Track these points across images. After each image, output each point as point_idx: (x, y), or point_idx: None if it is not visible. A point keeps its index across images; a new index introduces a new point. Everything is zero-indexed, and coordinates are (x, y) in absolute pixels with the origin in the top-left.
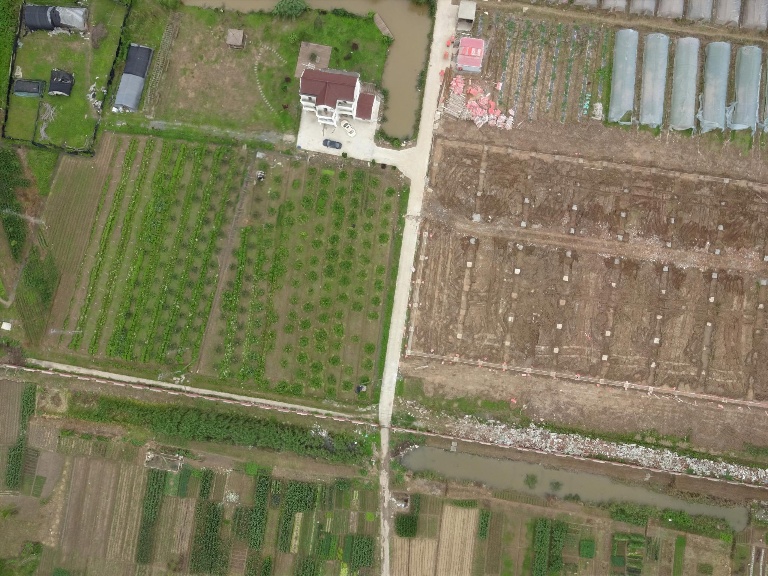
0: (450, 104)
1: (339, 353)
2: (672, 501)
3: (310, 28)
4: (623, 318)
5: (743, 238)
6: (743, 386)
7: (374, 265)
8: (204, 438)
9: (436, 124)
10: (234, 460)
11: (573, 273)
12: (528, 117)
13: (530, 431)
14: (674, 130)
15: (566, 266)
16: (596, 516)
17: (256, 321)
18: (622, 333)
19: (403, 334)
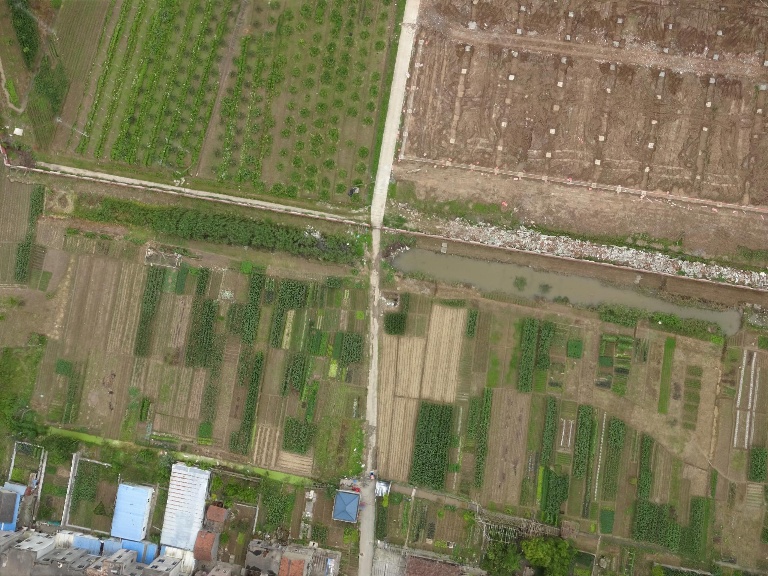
0: None
1: (334, 157)
2: (663, 305)
3: None
4: (617, 122)
5: (743, 43)
6: (739, 190)
7: (370, 72)
8: (201, 236)
9: None
10: (230, 259)
11: (568, 79)
12: None
13: (520, 232)
14: None
15: (561, 72)
16: (585, 317)
17: (254, 126)
18: (616, 137)
19: (397, 138)
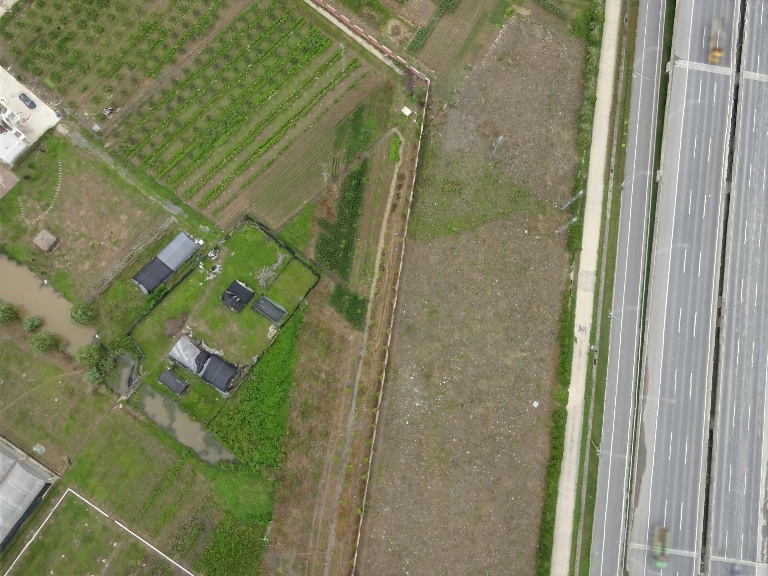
0: None
1: None
2: None
3: None
4: None
5: None
6: None
7: None
8: None
9: None
10: None
11: None
12: None
13: None
14: None
15: None
16: None
17: None
18: None
19: None
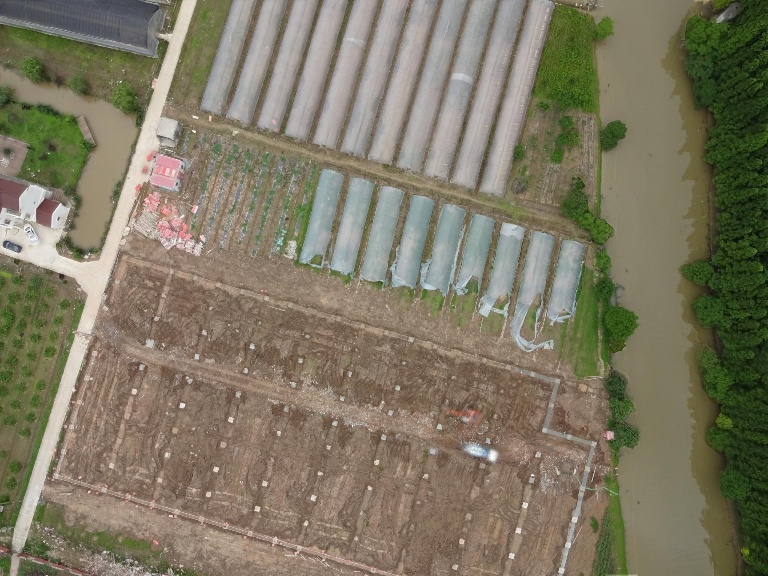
0: (140, 221)
1: None
2: None
3: None
4: (282, 470)
5: (418, 402)
6: (393, 558)
7: (36, 379)
8: None
9: (123, 240)
10: None
11: (238, 415)
12: (219, 245)
13: None
14: (365, 280)
15: (233, 407)
16: None
17: None
18: (278, 486)
19: (52, 456)
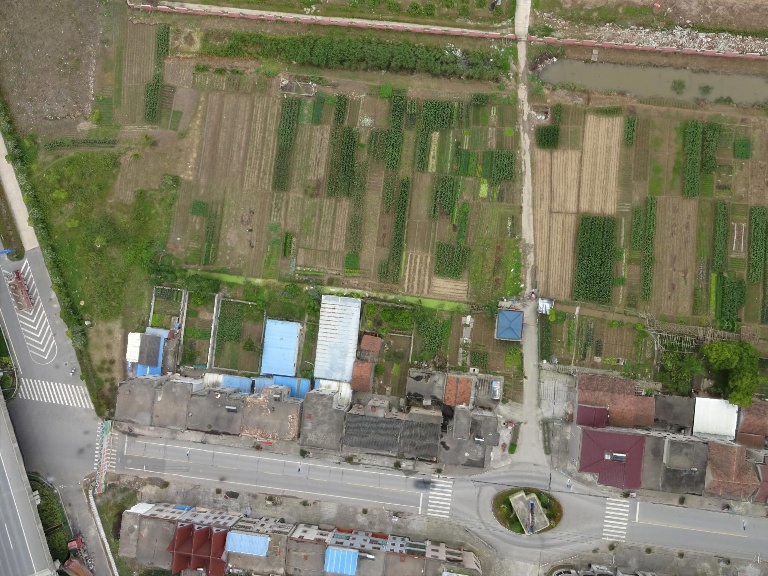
0: None
1: None
2: None
3: None
4: None
5: None
6: None
7: None
8: (337, 61)
9: None
10: (368, 84)
11: None
12: None
13: (676, 32)
14: None
15: None
16: (751, 115)
17: None
18: None
19: None
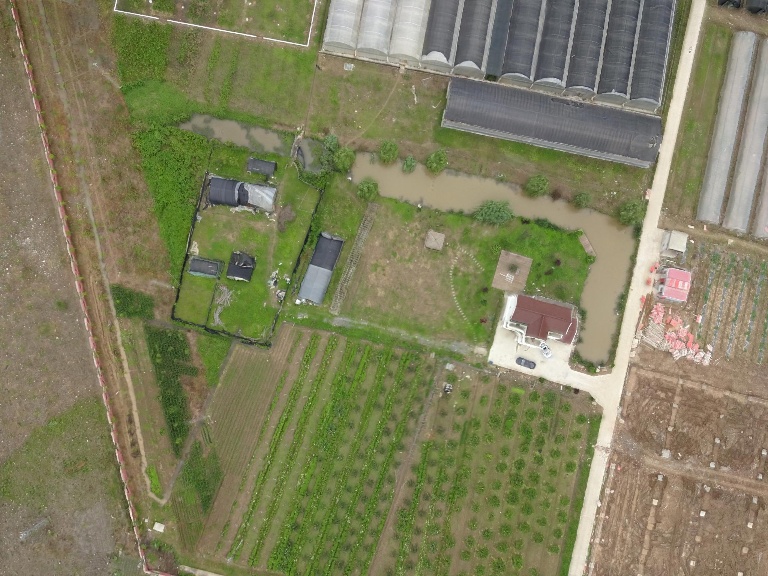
0: (649, 333)
1: None
2: None
3: (511, 236)
4: None
5: None
6: None
7: (558, 494)
8: None
9: (633, 352)
10: None
11: (758, 521)
12: (725, 354)
13: None
14: None
15: (751, 512)
16: None
17: (431, 545)
18: None
19: (583, 571)
